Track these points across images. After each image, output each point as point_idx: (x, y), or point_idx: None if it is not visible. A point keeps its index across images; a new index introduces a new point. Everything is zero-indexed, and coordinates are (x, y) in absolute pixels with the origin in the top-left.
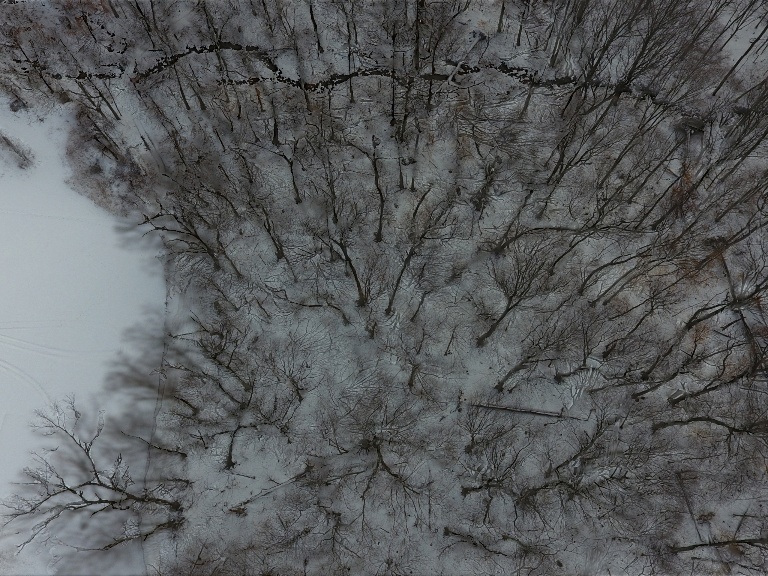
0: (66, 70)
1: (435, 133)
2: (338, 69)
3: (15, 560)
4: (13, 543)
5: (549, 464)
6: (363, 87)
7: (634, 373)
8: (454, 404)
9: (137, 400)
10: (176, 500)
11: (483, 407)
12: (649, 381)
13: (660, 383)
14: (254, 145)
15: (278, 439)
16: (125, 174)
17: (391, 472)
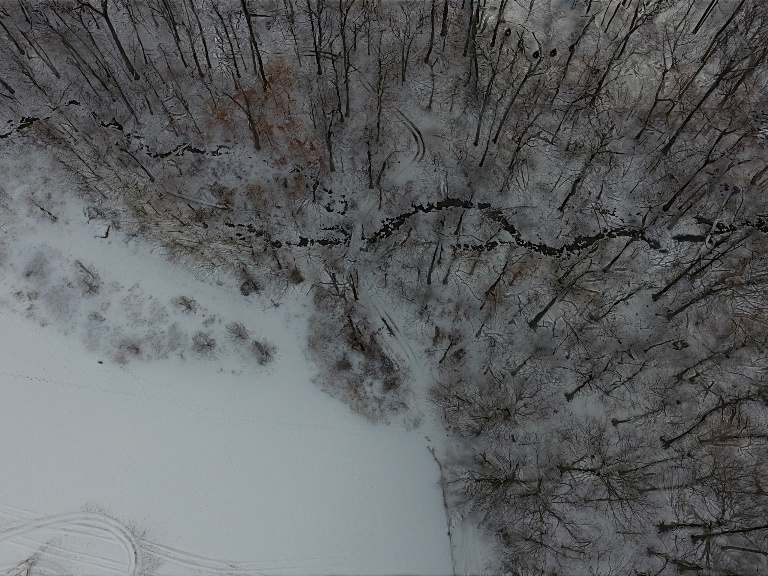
0: (286, 236)
1: (703, 309)
2: (582, 230)
3: None
4: None
5: None
6: (615, 253)
7: None
8: None
9: None
10: None
11: None
12: None
13: None
14: (508, 327)
15: None
16: (377, 370)
17: None
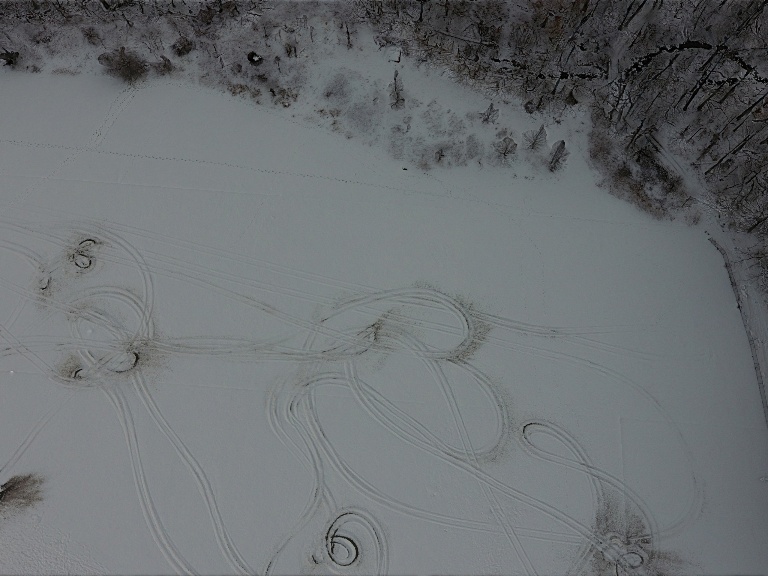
0: (549, 70)
1: None
2: None
3: (681, 561)
4: (673, 545)
5: None
6: None
7: None
8: None
9: (743, 404)
10: None
11: None
12: None
13: None
14: (760, 147)
15: None
16: (654, 177)
17: None
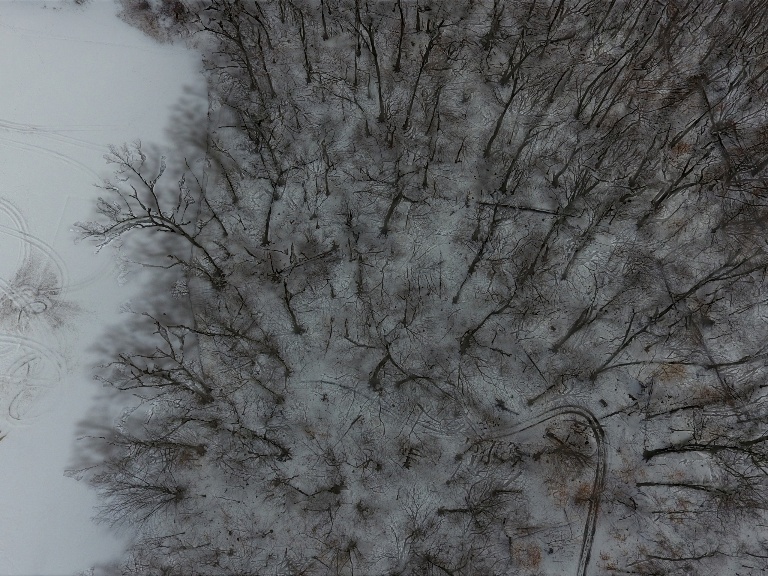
0: None
1: None
2: None
3: (80, 309)
4: (77, 296)
5: (546, 248)
6: None
7: (622, 181)
8: (463, 201)
9: None
10: (219, 268)
11: (488, 205)
12: (635, 187)
13: (645, 187)
14: None
15: (308, 225)
16: (170, 10)
17: (412, 200)
